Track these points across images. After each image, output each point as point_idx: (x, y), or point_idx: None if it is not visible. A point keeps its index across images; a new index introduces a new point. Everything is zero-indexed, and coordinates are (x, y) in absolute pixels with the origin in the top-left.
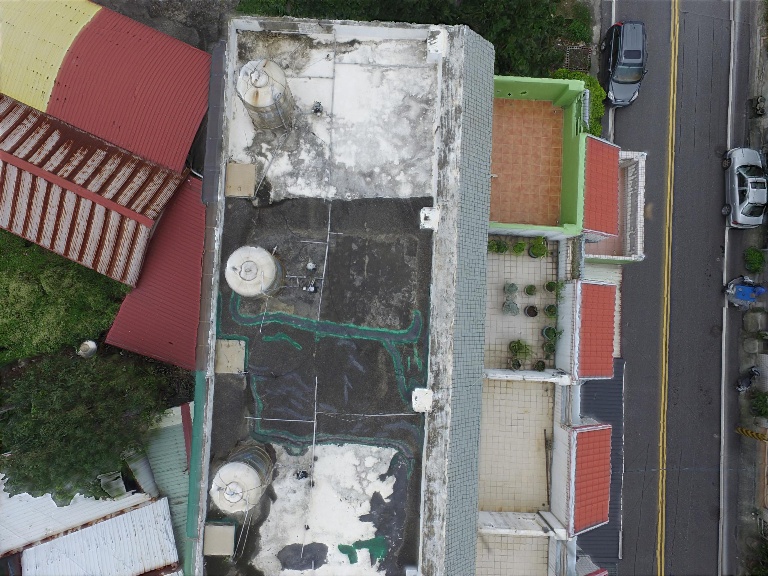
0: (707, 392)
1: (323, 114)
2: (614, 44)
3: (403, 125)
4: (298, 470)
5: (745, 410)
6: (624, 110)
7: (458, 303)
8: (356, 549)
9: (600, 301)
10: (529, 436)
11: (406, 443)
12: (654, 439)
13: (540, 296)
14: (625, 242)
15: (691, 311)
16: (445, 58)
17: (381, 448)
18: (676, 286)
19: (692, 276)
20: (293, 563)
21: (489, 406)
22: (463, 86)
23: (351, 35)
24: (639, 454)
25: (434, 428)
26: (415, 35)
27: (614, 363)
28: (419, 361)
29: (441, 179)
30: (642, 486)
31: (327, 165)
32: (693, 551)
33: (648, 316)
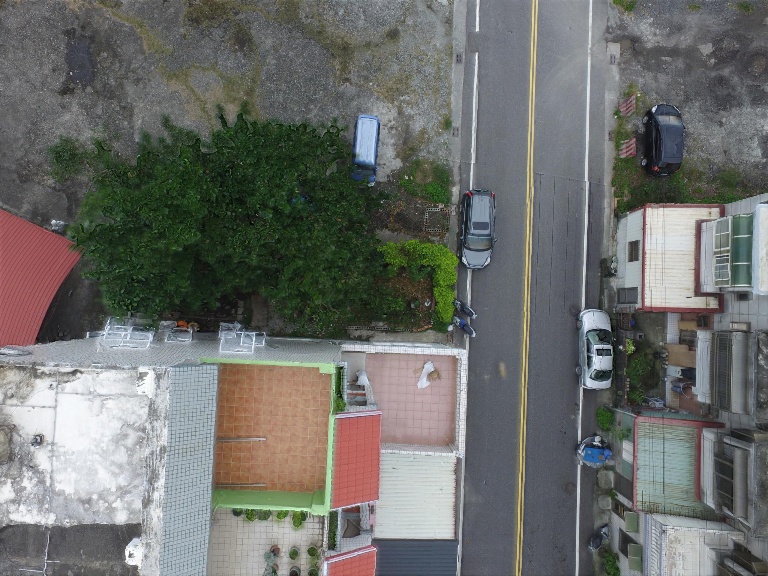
0: (562, 549)
1: (44, 443)
2: (466, 212)
3: (121, 453)
4: None
5: (599, 566)
6: (481, 271)
7: None
8: None
9: (354, 571)
10: None
11: None
12: None
13: (306, 556)
14: (455, 430)
15: (546, 469)
16: (151, 400)
17: None
18: (531, 444)
19: (547, 434)
20: None
21: None
22: (168, 427)
23: None
24: None
25: None
26: None
27: (448, 545)
28: None
29: (145, 518)
30: None
31: (48, 492)
32: None
33: (504, 474)
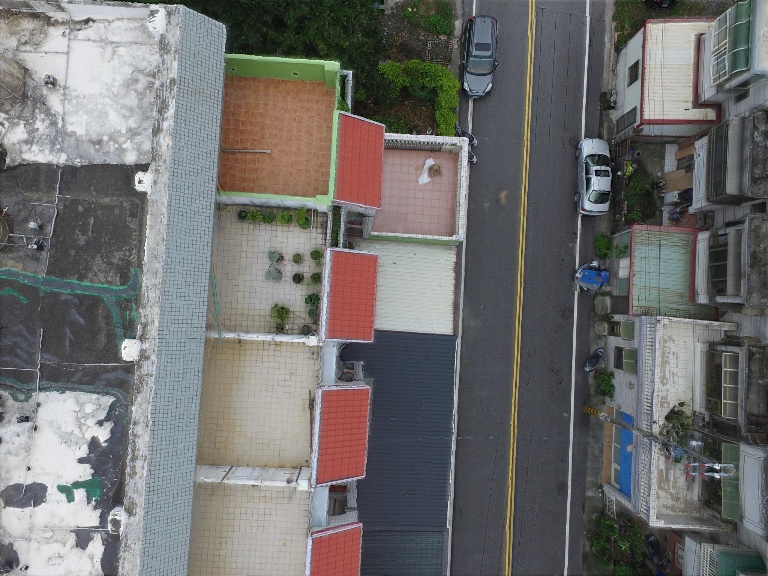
0: (558, 372)
1: (57, 86)
2: (468, 37)
3: (131, 97)
4: (20, 415)
5: (595, 390)
6: (482, 101)
7: (169, 261)
8: (74, 489)
9: (356, 268)
10: (295, 396)
11: (123, 391)
12: (506, 417)
13: (309, 265)
14: (455, 224)
15: (544, 294)
16: (162, 35)
17: (101, 395)
18: (530, 270)
19: (545, 261)
20: (14, 501)
21: (258, 368)
22: (178, 61)
23: (85, 14)
24: (491, 432)
25: (140, 375)
26: (142, 14)
27: (446, 340)
28: (137, 315)
29: (154, 146)
30: (493, 463)
31: (60, 133)
32: (541, 526)
33: (502, 299)
